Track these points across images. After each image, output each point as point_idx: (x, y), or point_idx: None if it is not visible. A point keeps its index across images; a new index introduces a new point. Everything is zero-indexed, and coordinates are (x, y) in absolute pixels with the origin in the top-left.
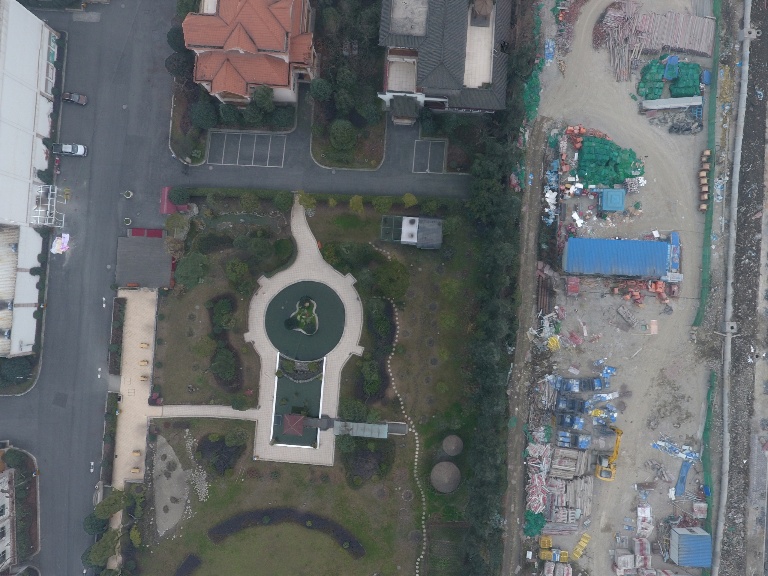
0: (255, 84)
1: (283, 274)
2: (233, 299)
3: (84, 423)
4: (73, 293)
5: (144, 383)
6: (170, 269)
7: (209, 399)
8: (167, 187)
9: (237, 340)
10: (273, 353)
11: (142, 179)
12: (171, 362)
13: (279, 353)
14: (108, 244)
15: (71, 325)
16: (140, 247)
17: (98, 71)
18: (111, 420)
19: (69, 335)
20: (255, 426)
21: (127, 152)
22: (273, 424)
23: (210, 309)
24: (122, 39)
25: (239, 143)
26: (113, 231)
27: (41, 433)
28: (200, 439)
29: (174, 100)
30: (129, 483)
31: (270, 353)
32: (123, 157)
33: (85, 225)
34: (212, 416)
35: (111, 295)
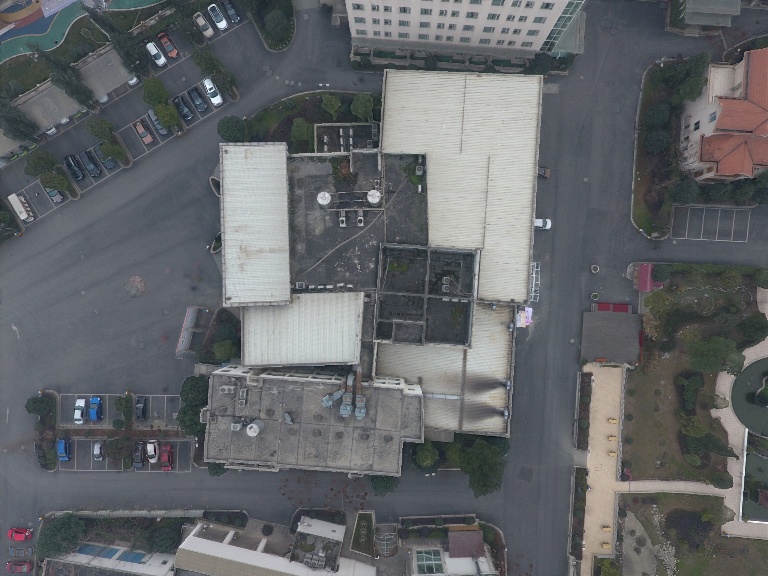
0: (761, 165)
1: (749, 350)
2: (701, 375)
3: (550, 497)
4: (537, 367)
5: (611, 458)
6: (637, 344)
7: (676, 475)
8: (650, 265)
9: (704, 416)
10: (740, 429)
11: (605, 253)
12: (637, 437)
13: (748, 429)
14: (572, 318)
15: (535, 399)
16: (606, 322)
17: (558, 143)
18: (583, 496)
19: (534, 409)
20: (723, 502)
21: (589, 225)
22: (742, 500)
23: (679, 385)
24: (581, 111)
25: (703, 217)
26: (576, 305)
27: (507, 507)
28: (668, 515)
29: (636, 173)
30: (601, 559)
31: (737, 429)
32: (585, 230)
33: (548, 299)
34: (680, 492)
35: (575, 369)
